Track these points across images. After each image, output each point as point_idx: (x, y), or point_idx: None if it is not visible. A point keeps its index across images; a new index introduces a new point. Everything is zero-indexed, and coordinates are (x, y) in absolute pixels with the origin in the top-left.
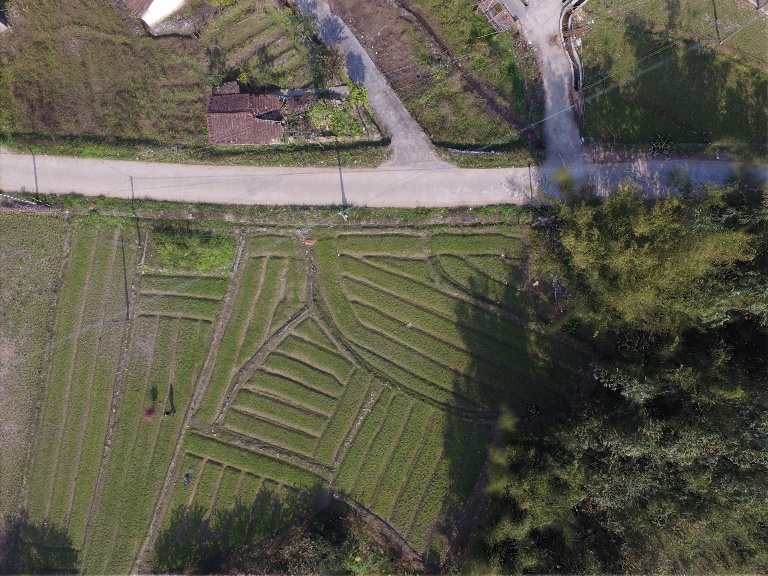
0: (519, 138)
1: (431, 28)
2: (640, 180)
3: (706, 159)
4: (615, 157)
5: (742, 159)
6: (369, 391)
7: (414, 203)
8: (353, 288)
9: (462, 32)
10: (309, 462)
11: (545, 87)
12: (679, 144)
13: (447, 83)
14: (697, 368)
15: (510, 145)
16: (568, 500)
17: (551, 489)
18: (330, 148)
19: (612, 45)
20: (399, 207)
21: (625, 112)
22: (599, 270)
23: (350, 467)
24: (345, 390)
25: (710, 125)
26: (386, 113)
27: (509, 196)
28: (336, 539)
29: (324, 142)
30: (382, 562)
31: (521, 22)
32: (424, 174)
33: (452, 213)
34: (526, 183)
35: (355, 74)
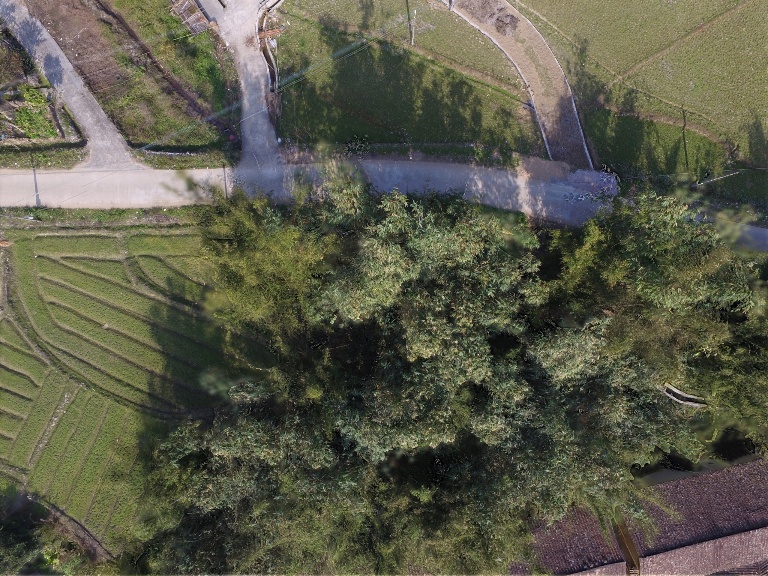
0: (220, 139)
1: (132, 30)
2: (334, 180)
3: (399, 159)
4: (309, 158)
5: (435, 159)
6: (64, 392)
7: (108, 204)
8: (49, 289)
9: (159, 34)
10: (3, 464)
11: (242, 88)
12: (374, 144)
13: (146, 85)
14: (310, 368)
15: (208, 146)
16: (167, 500)
17: (157, 489)
18: (26, 150)
19: (309, 46)
20: (93, 208)
21: (322, 113)
22: (215, 270)
23: (44, 469)
24: (40, 391)
25: (406, 125)
26: (83, 115)
27: (204, 197)
28: (14, 541)
29: (20, 144)
30: (75, 564)
31: (218, 24)
32: (118, 175)
33: (145, 214)
34: (220, 184)
35: (53, 76)
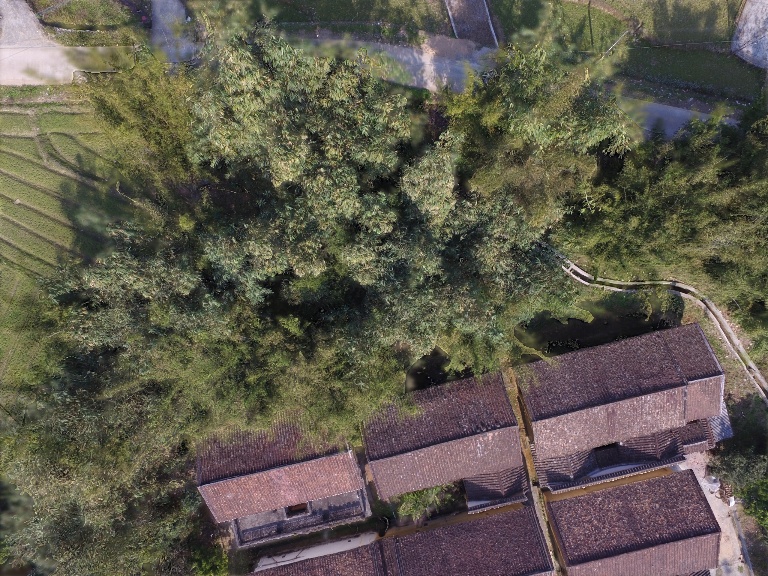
0: (131, 19)
1: None
2: None
3: (306, 37)
4: (217, 35)
5: (341, 37)
6: None
7: (20, 81)
8: None
9: None
10: None
11: None
12: (282, 23)
13: None
14: (191, 211)
15: None
16: (46, 334)
17: (39, 327)
18: None
19: None
20: (5, 85)
21: None
22: None
23: None
24: None
25: (314, 4)
26: None
27: None
28: None
29: None
30: None
31: None
32: (30, 52)
33: (56, 90)
34: (130, 61)
35: None
